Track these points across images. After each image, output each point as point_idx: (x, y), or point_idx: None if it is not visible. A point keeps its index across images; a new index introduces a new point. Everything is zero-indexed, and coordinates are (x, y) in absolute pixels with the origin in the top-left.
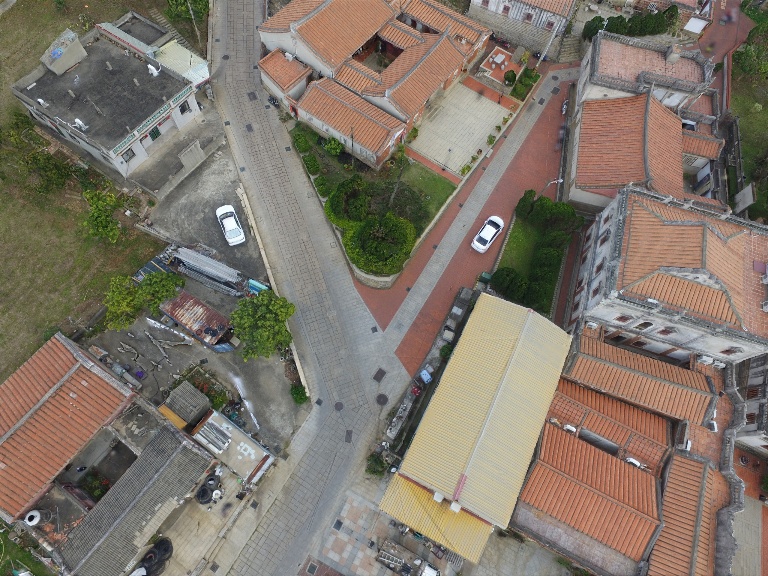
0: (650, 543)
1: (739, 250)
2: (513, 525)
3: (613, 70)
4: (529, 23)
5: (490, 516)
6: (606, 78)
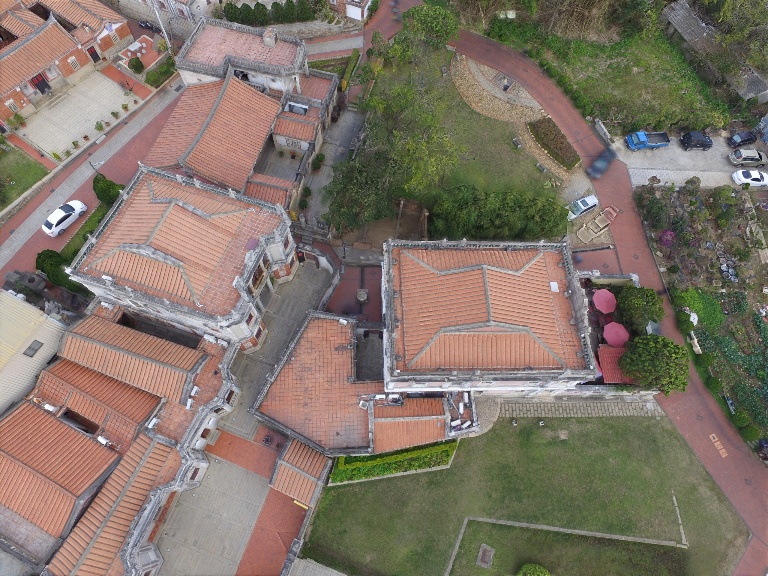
0: (69, 520)
1: (232, 227)
2: None
3: (204, 54)
4: (166, 11)
5: None
6: (186, 62)
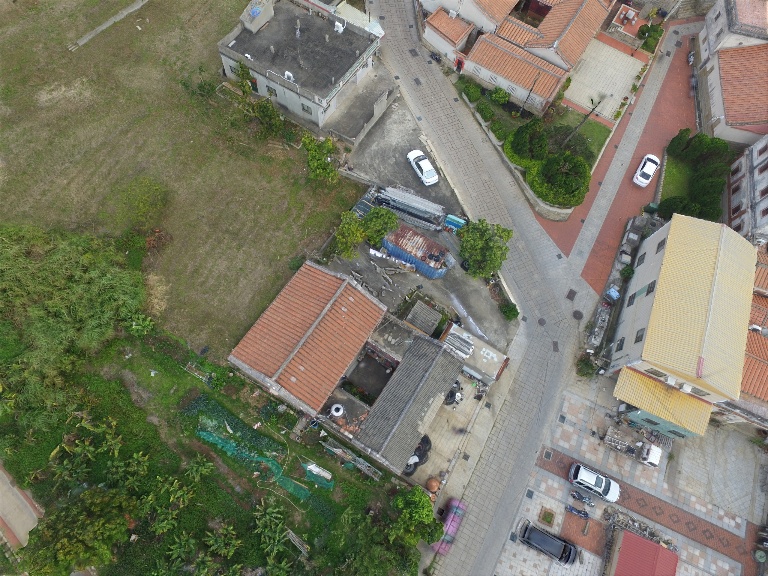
0: None
1: None
2: (729, 404)
3: (748, 20)
4: None
5: (726, 390)
6: (746, 27)
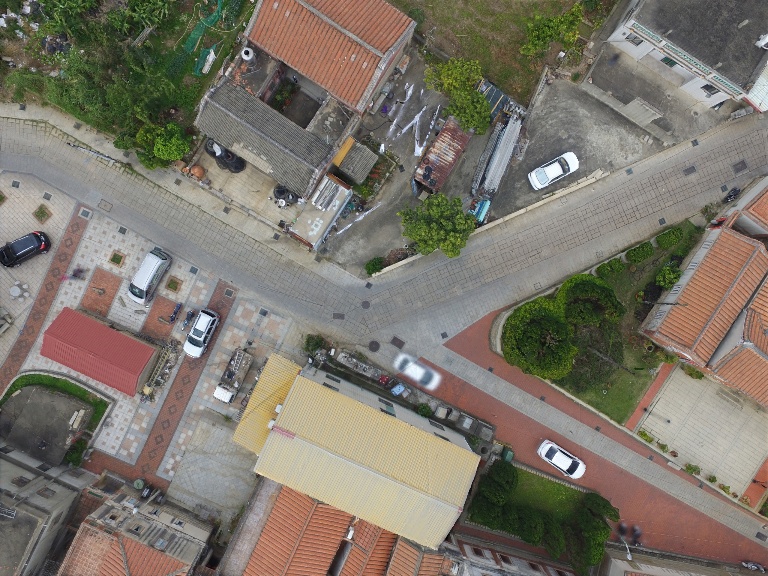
0: None
1: None
2: None
3: None
4: None
5: (263, 458)
6: None
